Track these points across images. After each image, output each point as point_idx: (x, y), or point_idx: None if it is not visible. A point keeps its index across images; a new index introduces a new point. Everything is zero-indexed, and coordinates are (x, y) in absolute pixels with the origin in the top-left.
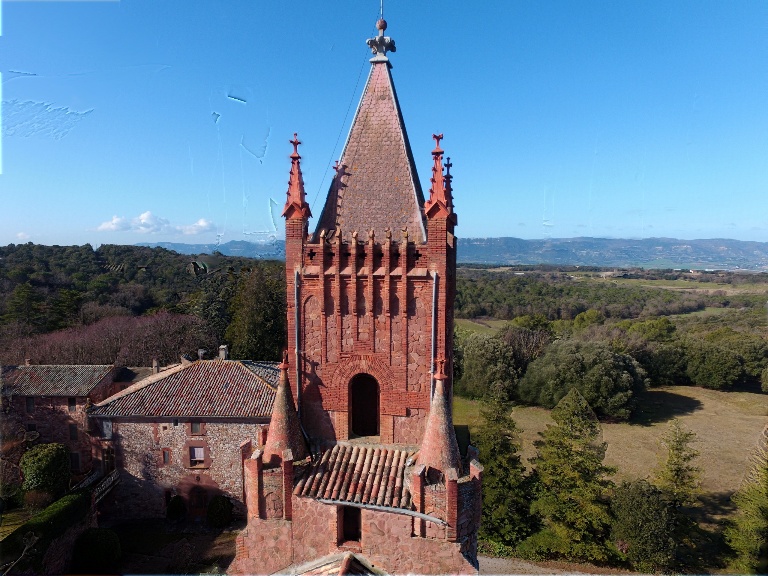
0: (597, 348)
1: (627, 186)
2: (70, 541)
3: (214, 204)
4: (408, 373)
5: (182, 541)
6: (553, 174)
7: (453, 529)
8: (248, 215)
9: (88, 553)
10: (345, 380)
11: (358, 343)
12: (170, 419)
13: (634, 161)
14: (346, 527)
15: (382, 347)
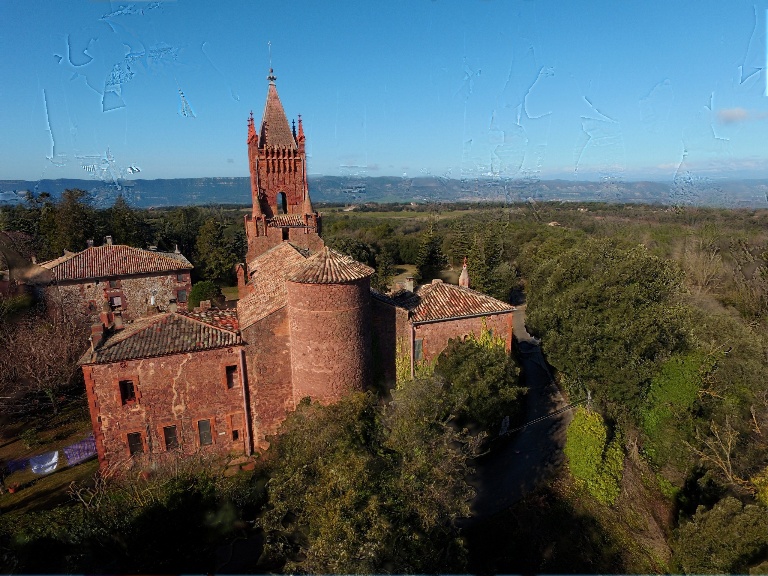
0: (347, 237)
1: (357, 130)
2: None
3: (36, 131)
4: (296, 191)
5: None
6: (310, 119)
7: (316, 229)
8: (78, 141)
9: None
10: (275, 195)
11: (279, 182)
12: (93, 280)
13: (360, 113)
14: (284, 237)
15: (287, 183)
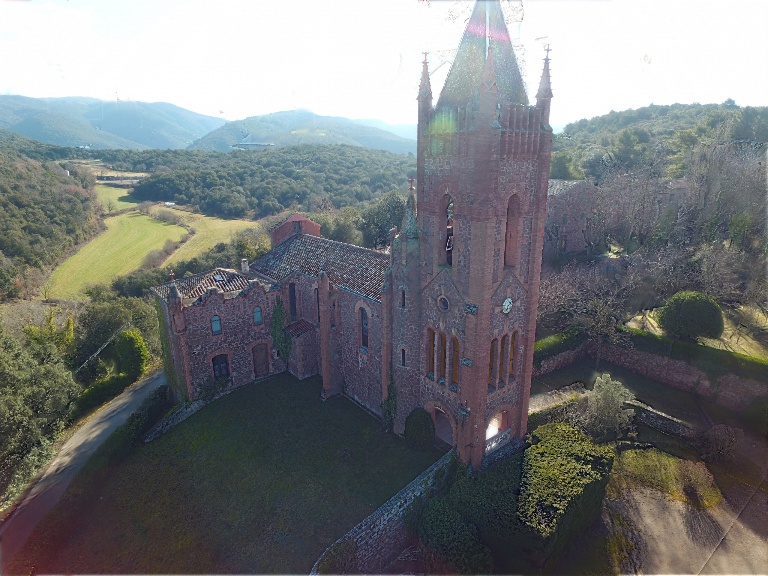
0: None
1: None
2: (754, 392)
3: None
4: None
5: (739, 429)
6: None
7: None
8: None
9: (750, 407)
10: None
11: None
12: None
13: None
14: None
15: None
